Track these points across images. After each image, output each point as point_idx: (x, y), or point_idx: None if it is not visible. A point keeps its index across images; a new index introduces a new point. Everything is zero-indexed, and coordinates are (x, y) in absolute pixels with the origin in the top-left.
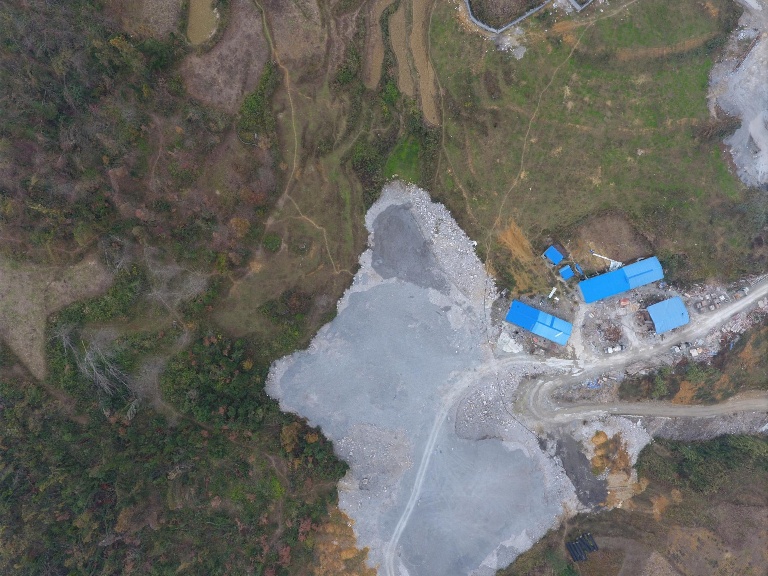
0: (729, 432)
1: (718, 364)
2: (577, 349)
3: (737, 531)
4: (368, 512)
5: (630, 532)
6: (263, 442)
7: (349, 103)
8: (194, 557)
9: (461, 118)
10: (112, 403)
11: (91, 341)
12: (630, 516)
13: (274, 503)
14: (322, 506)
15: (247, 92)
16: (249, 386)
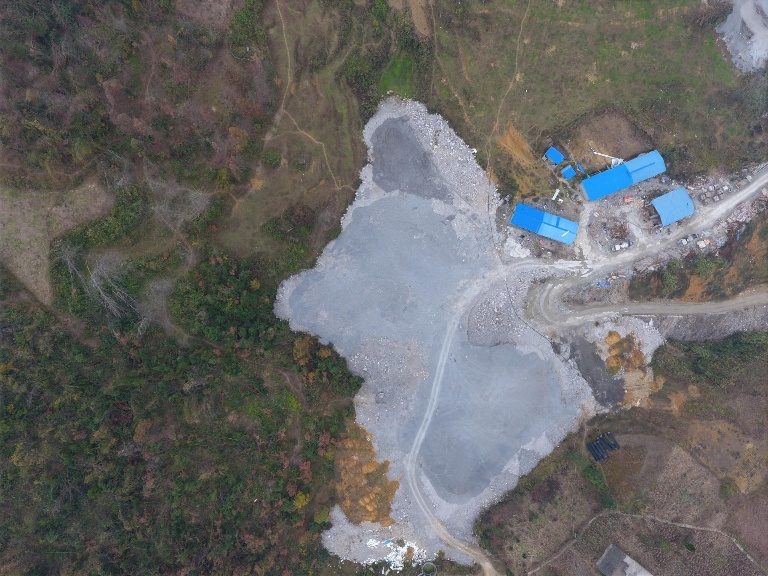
0: (741, 329)
1: (726, 255)
2: (584, 249)
3: (757, 421)
4: (386, 425)
5: (650, 429)
6: (276, 359)
7: (339, 17)
8: (215, 472)
9: (452, 26)
10: (122, 325)
11: (96, 266)
12: (649, 413)
13: (291, 418)
14: (340, 421)
15: (236, 7)
16: (258, 307)
